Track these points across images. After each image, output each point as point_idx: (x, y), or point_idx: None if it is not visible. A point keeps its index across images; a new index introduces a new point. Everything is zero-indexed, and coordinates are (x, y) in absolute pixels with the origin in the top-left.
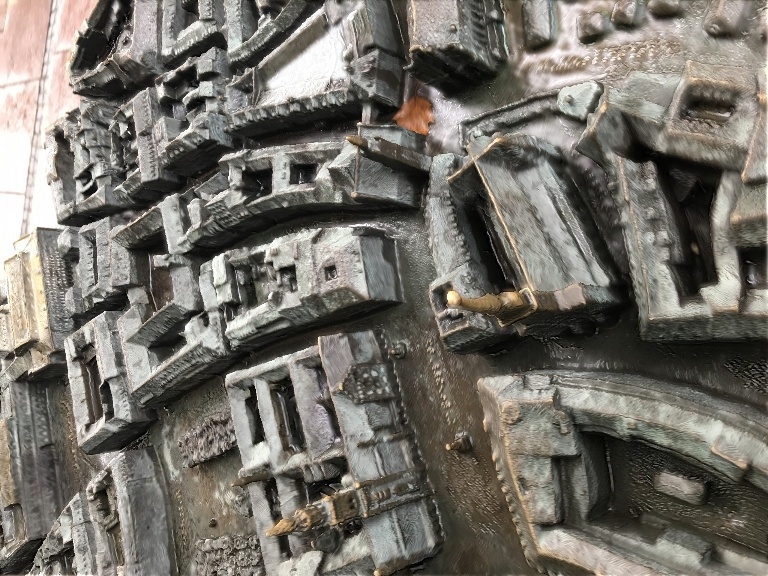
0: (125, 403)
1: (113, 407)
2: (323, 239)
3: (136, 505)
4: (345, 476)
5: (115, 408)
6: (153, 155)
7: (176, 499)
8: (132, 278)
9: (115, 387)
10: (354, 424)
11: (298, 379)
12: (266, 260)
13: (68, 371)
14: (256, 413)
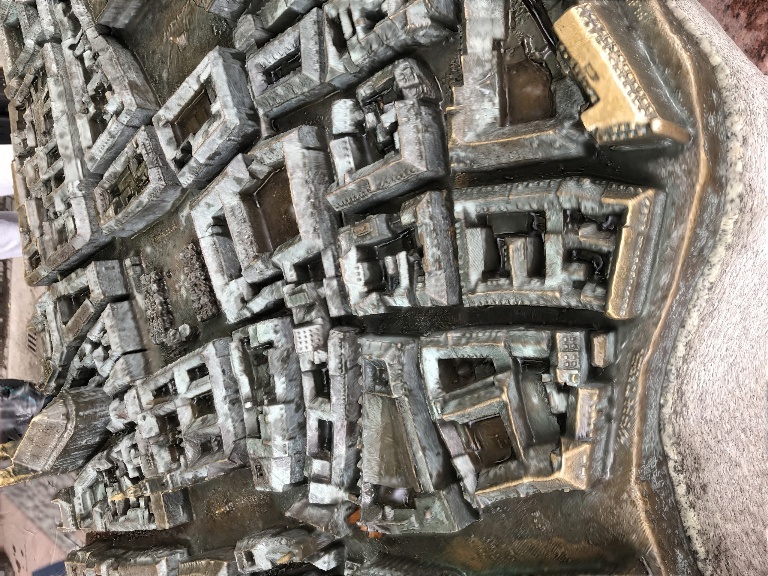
0: (190, 178)
1: (181, 170)
2: (277, 464)
3: (146, 209)
4: (183, 460)
5: (182, 172)
6: (355, 200)
7: (172, 224)
8: (267, 164)
9: (194, 164)
10: (203, 471)
11: (213, 428)
12: (263, 407)
13: (189, 76)
14: (204, 365)
